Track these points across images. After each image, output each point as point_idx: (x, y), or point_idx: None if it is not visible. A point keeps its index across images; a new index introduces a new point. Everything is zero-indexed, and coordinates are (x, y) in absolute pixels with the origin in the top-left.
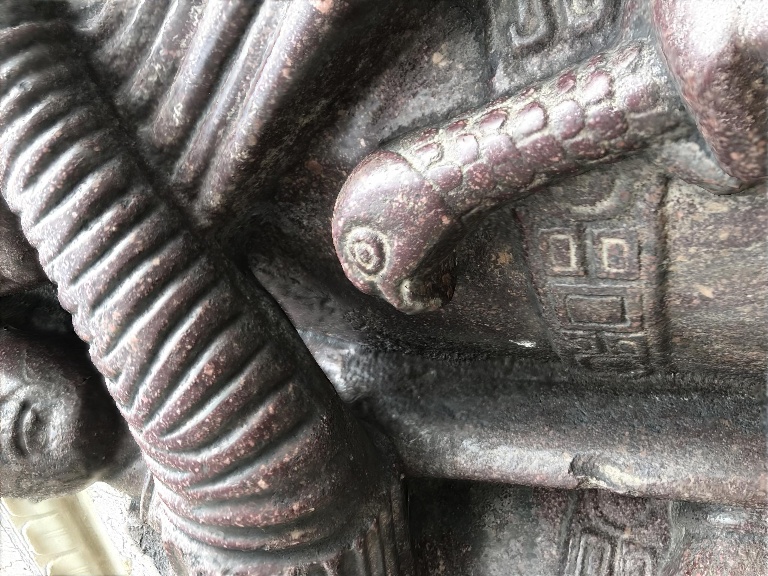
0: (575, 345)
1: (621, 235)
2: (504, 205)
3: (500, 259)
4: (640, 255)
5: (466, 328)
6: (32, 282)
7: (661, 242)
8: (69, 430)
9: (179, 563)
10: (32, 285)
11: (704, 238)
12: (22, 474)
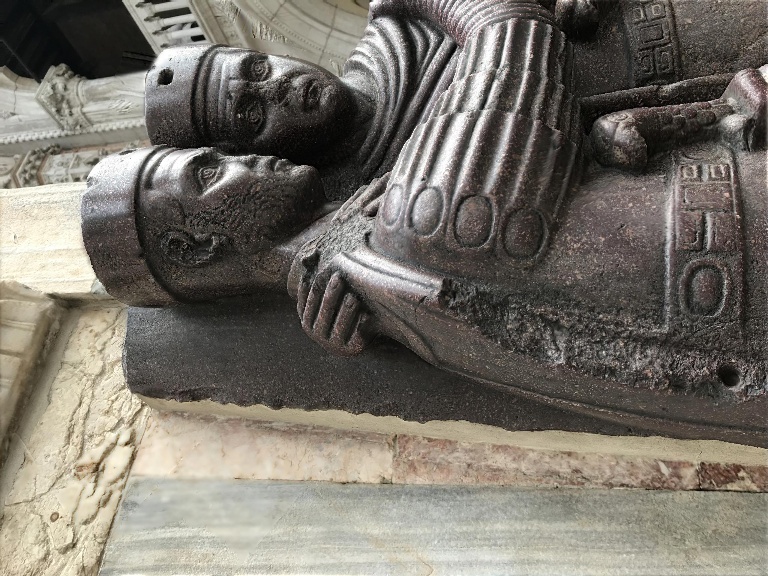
0: (643, 67)
1: (657, 3)
2: (617, 3)
3: (613, 29)
4: (665, 8)
5: (590, 86)
6: (332, 108)
7: (670, 4)
8: (310, 167)
9: (484, 37)
10: (322, 118)
11: (683, 1)
12: (261, 179)
